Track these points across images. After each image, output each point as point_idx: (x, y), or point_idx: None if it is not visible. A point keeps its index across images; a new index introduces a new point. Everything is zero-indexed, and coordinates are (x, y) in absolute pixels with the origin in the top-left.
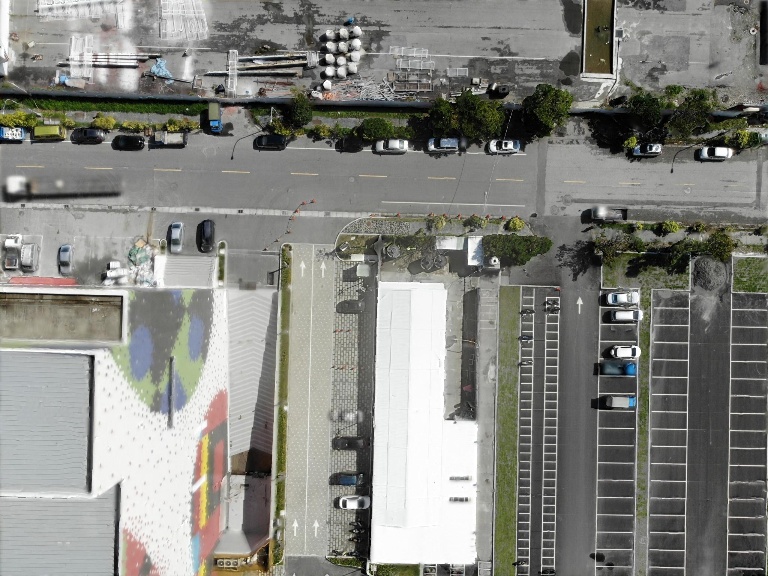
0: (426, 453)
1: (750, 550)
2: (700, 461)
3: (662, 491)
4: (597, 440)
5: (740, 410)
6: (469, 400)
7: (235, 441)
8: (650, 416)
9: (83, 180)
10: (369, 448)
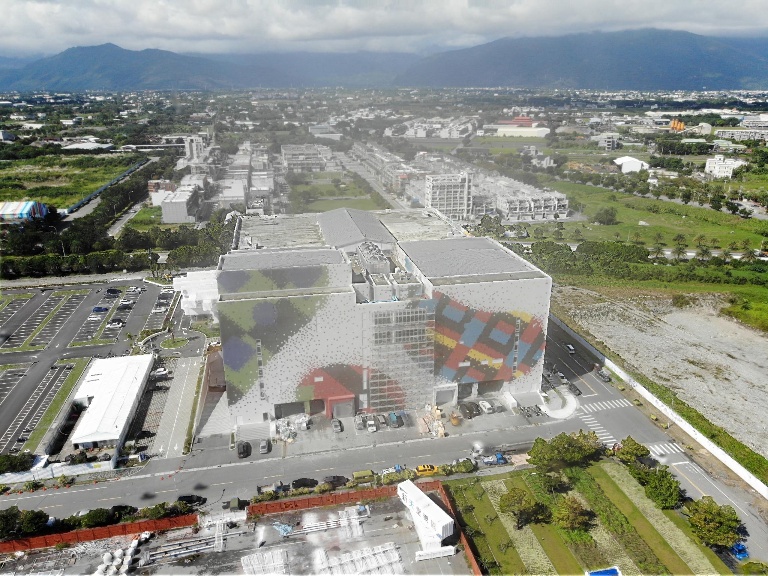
0: None
1: None
2: None
3: None
4: None
5: None
6: (76, 412)
7: None
8: None
9: (336, 462)
10: None
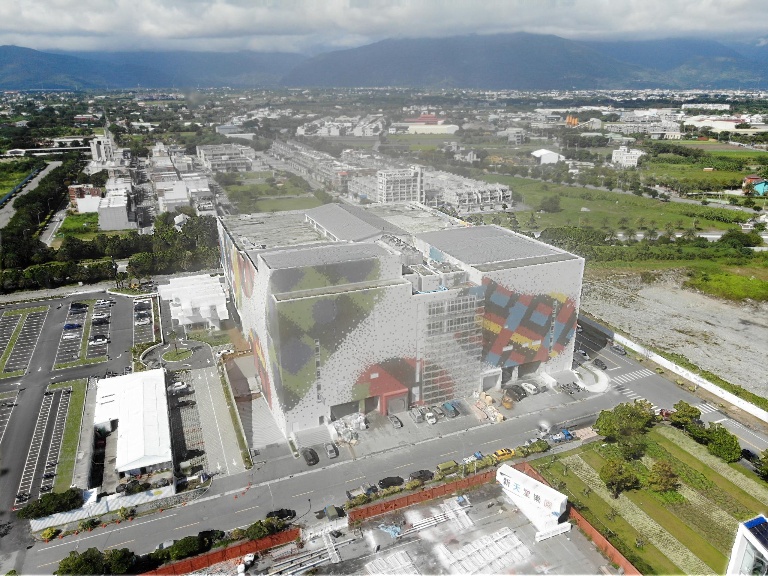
0: None
1: None
2: None
3: None
4: (0, 447)
5: None
6: (100, 439)
7: None
8: None
9: (411, 458)
10: None
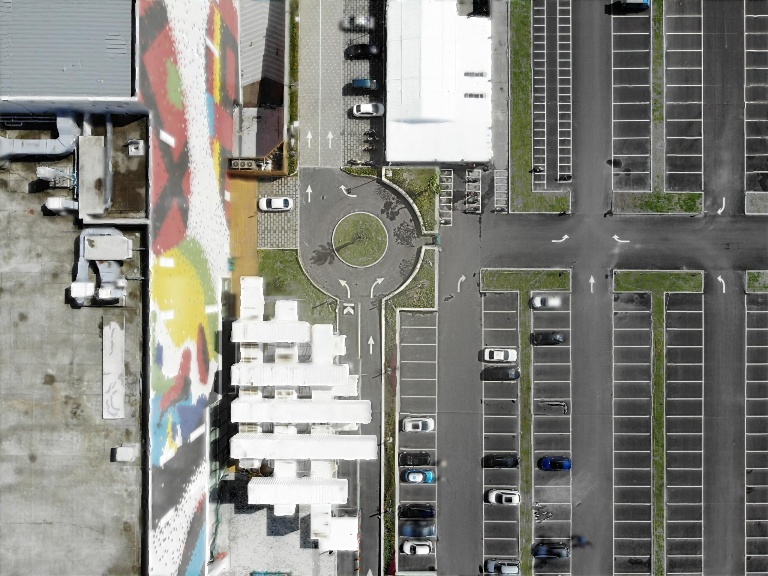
0: (440, 45)
1: (767, 153)
2: (716, 65)
3: (678, 96)
4: (612, 46)
5: (755, 13)
6: (482, 7)
7: (246, 71)
8: (664, 21)
9: None
10: (382, 59)
